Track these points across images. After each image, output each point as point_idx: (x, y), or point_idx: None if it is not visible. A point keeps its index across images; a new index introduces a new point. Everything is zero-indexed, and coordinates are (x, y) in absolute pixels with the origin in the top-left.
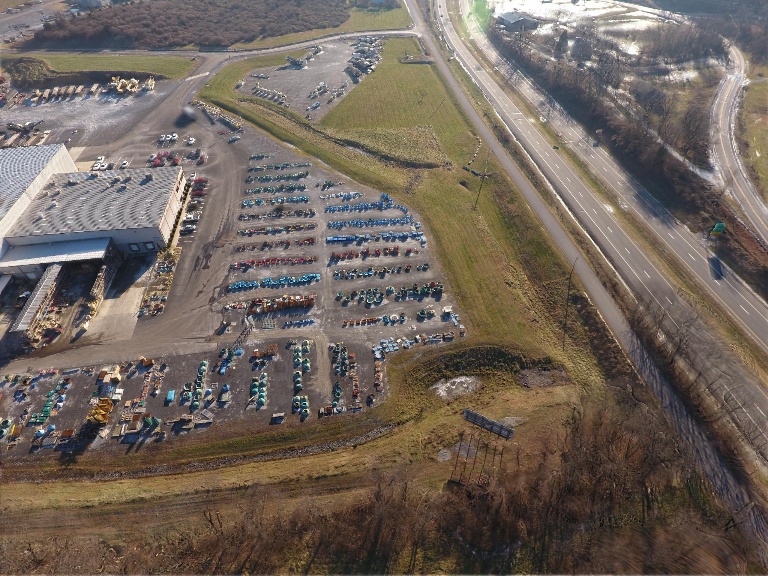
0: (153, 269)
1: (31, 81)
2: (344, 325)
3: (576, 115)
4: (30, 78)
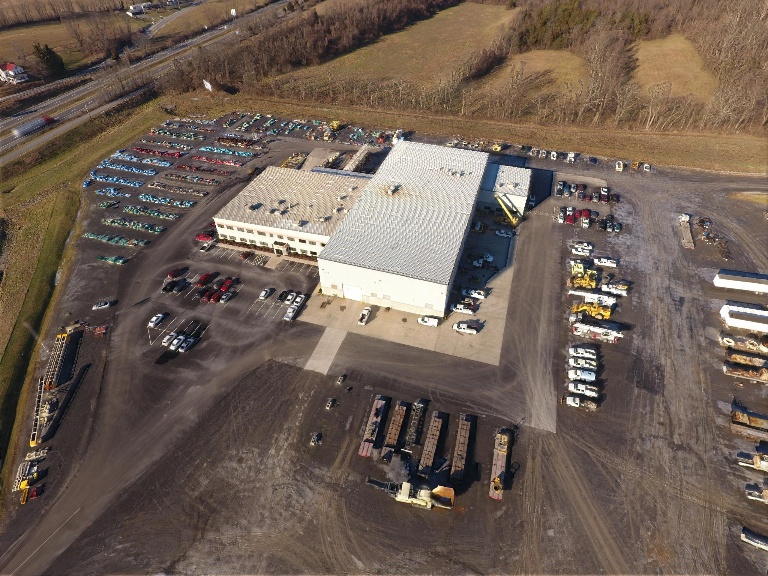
0: None
1: None
2: None
3: None
4: None
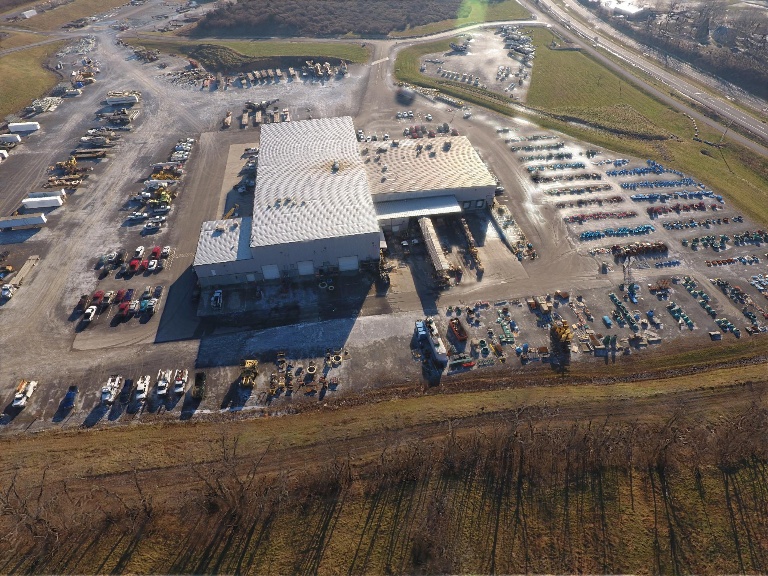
0: (493, 223)
1: (229, 65)
2: (709, 265)
3: (761, 94)
4: (227, 62)
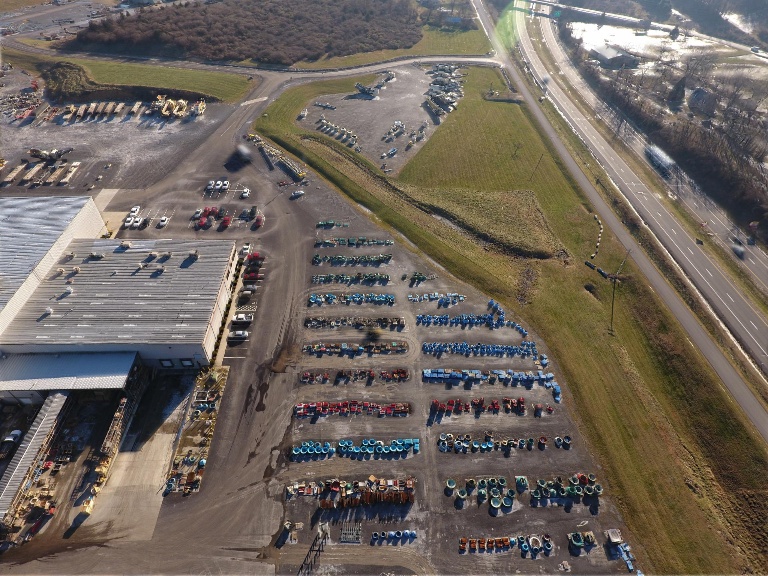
0: (189, 401)
1: (66, 93)
2: (462, 549)
3: (714, 194)
4: (66, 89)
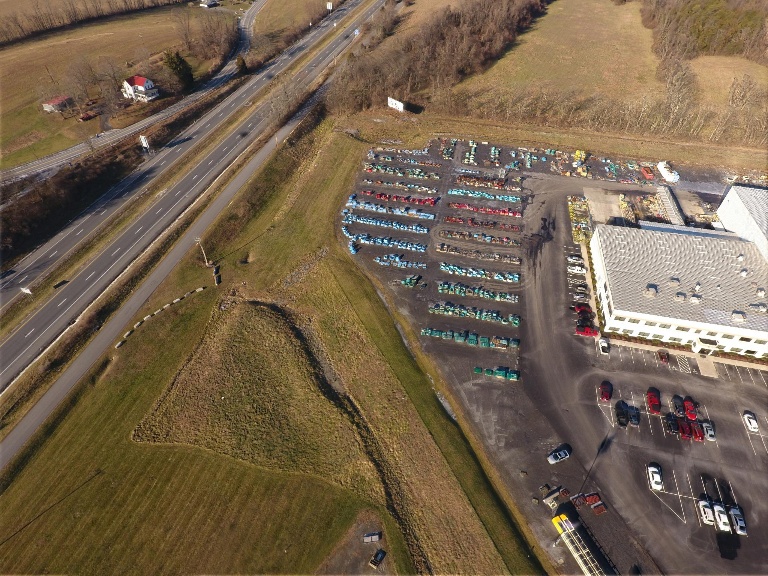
0: (593, 232)
1: None
2: None
3: None
4: None
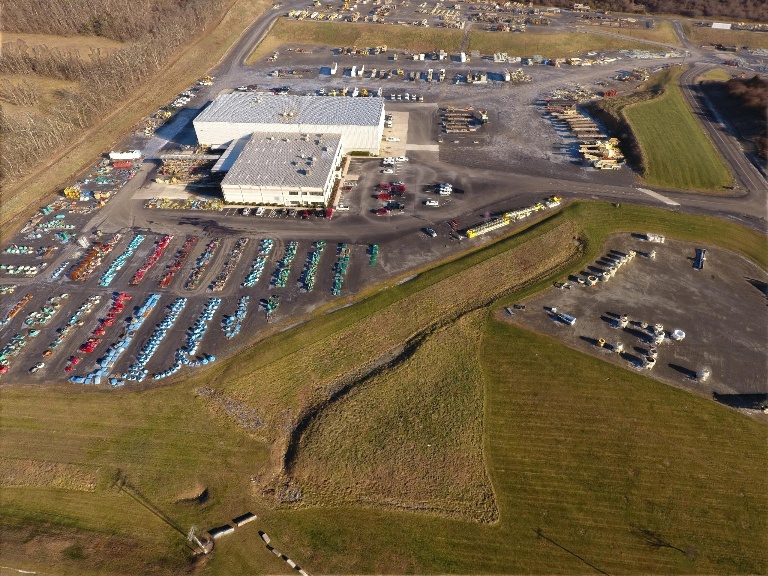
0: None
1: (596, 104)
2: (27, 295)
3: None
4: (603, 102)
